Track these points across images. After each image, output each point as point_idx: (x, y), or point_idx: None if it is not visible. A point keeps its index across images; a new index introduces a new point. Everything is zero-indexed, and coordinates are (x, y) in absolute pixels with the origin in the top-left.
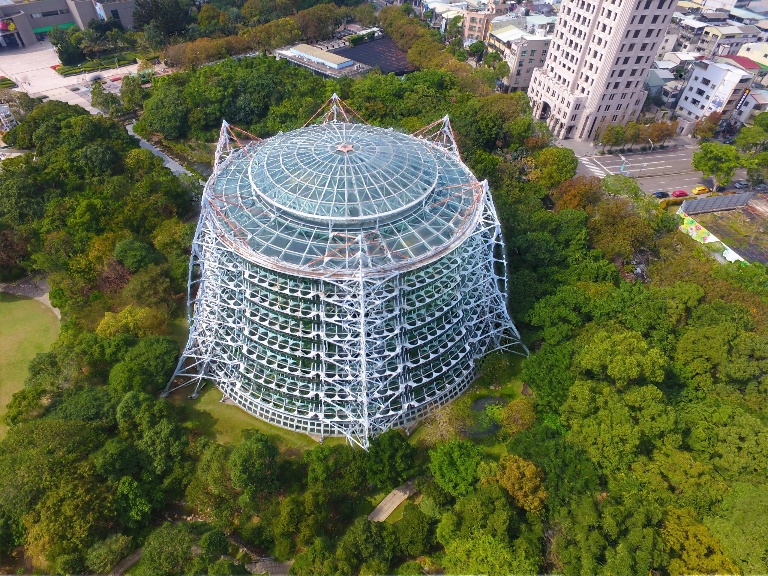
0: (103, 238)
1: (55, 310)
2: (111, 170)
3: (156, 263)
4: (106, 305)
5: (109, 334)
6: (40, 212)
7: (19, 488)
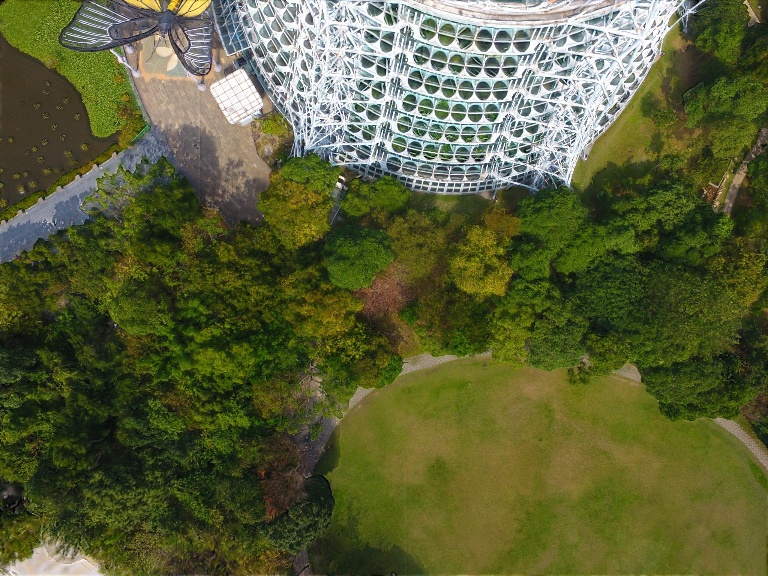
0: (320, 308)
1: (370, 389)
2: (33, 351)
3: (374, 228)
4: (435, 298)
5: (508, 278)
6: (191, 440)
7: (737, 317)
